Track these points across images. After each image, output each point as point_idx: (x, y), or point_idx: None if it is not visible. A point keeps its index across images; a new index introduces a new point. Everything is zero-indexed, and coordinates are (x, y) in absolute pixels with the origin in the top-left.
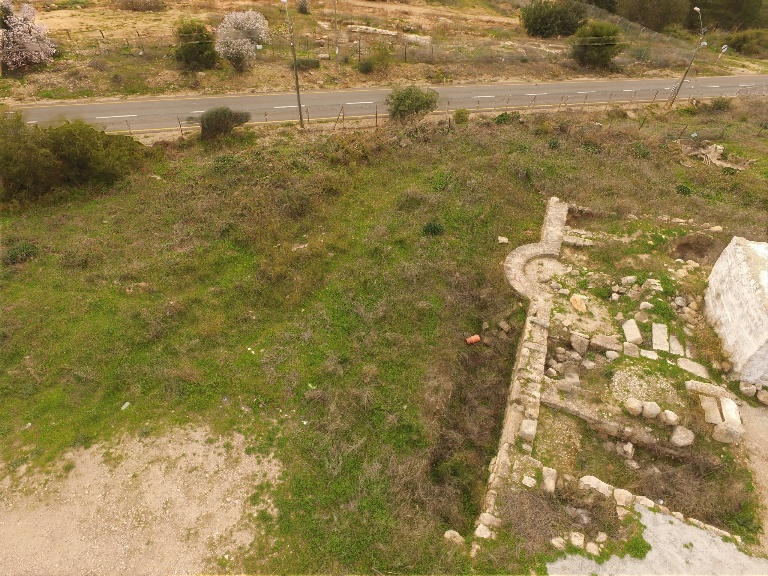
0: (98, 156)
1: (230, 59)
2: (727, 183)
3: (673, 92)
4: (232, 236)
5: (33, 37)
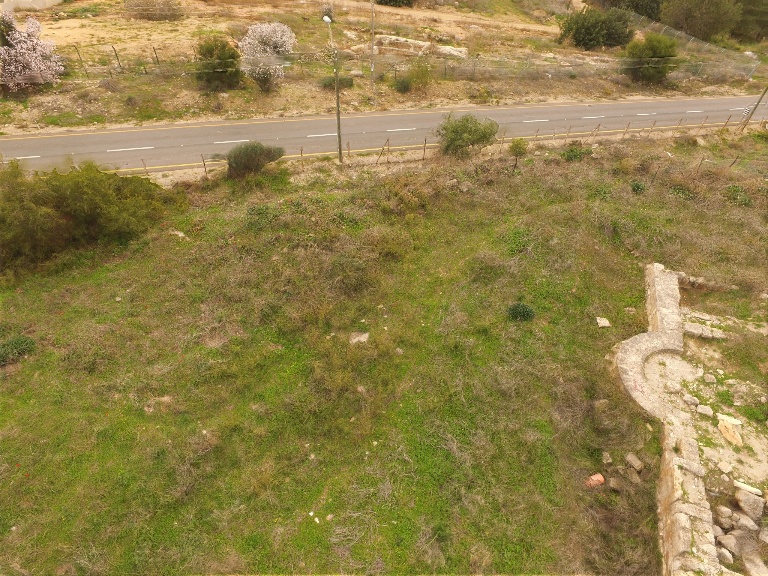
0: (110, 213)
1: (256, 79)
2: None
3: (745, 115)
4: (274, 322)
5: (38, 55)
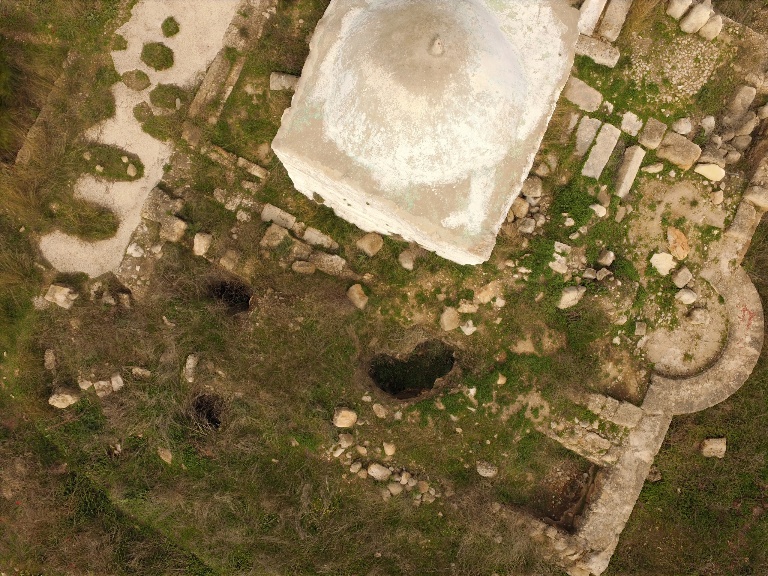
0: None
1: None
2: None
3: None
4: None
5: None
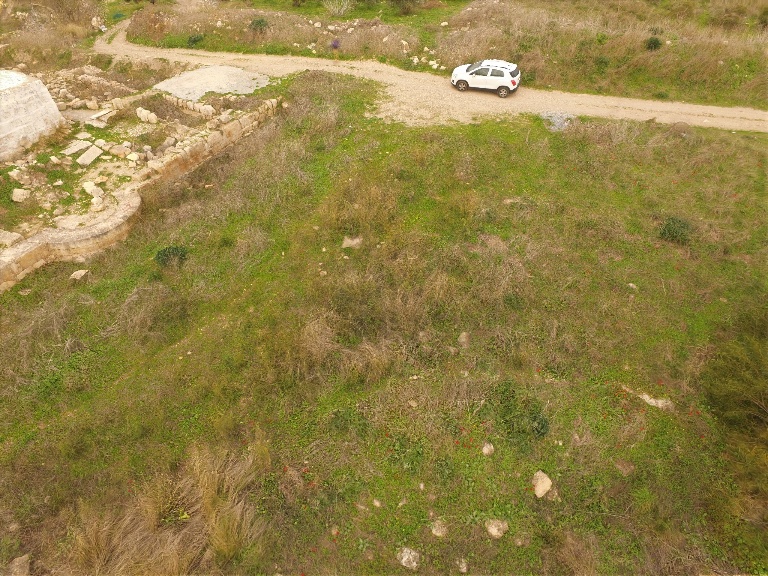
0: (762, 343)
1: None
2: None
3: None
4: None
5: None
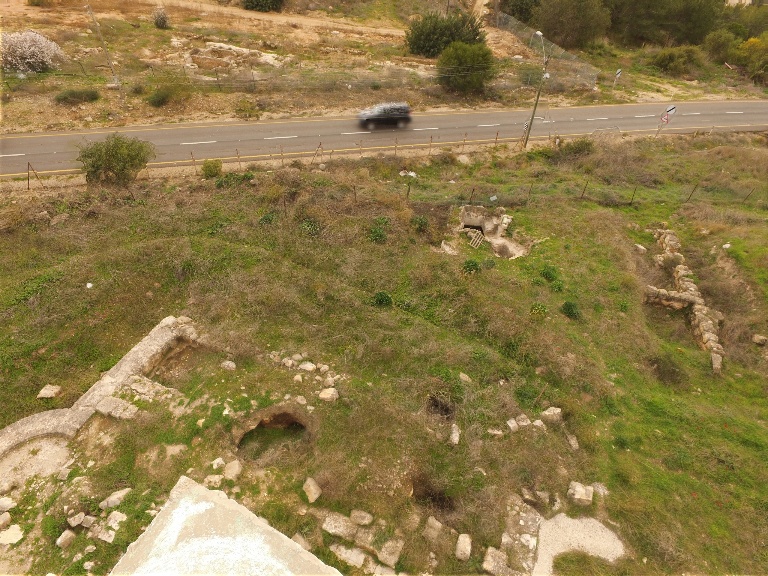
0: None
1: None
2: (453, 288)
3: (525, 131)
4: None
5: None
